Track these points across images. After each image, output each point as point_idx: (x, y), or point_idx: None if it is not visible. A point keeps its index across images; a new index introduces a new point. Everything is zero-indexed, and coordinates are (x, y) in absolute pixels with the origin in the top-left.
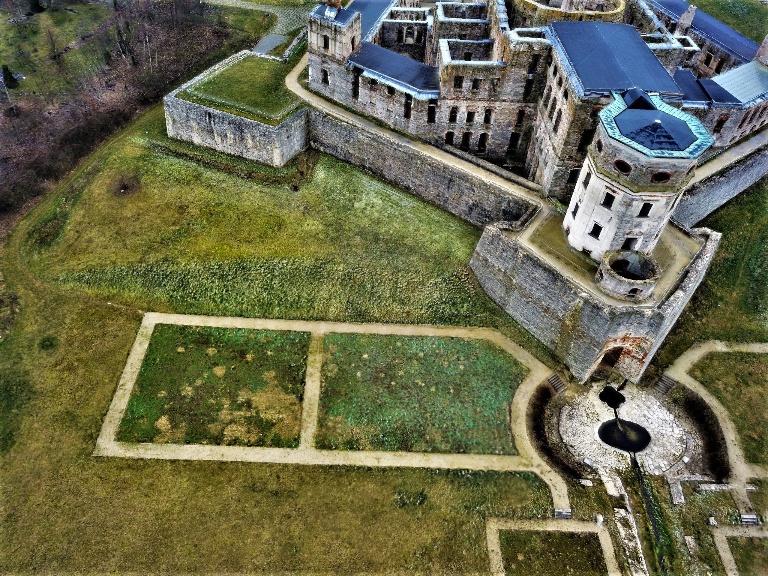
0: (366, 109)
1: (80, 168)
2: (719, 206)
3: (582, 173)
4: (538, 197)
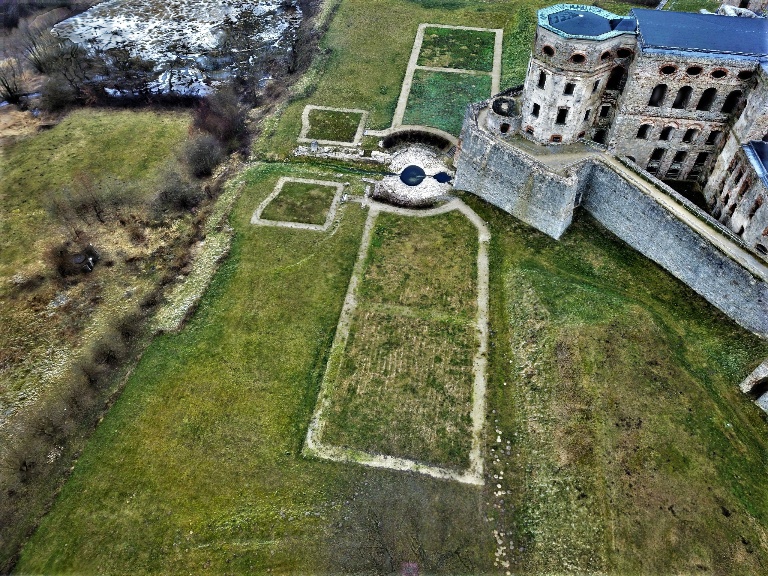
0: None
1: None
2: (670, 271)
3: None
4: None
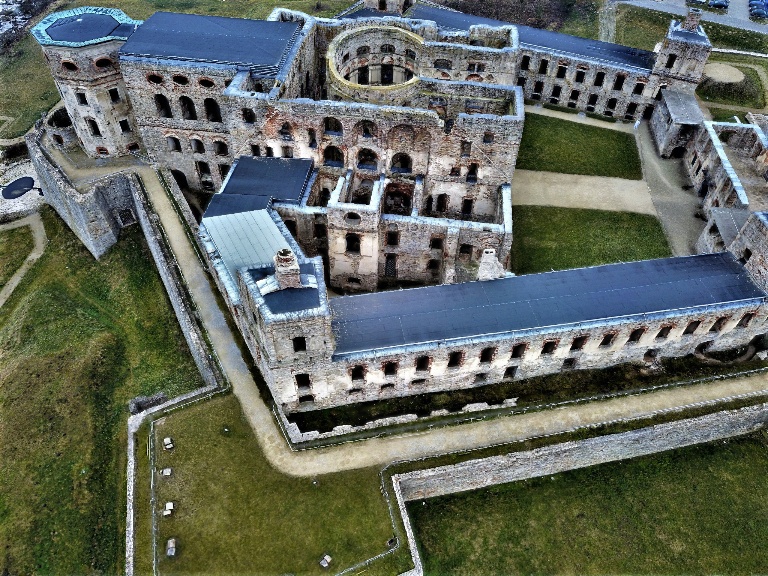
0: None
1: None
2: None
3: None
4: None
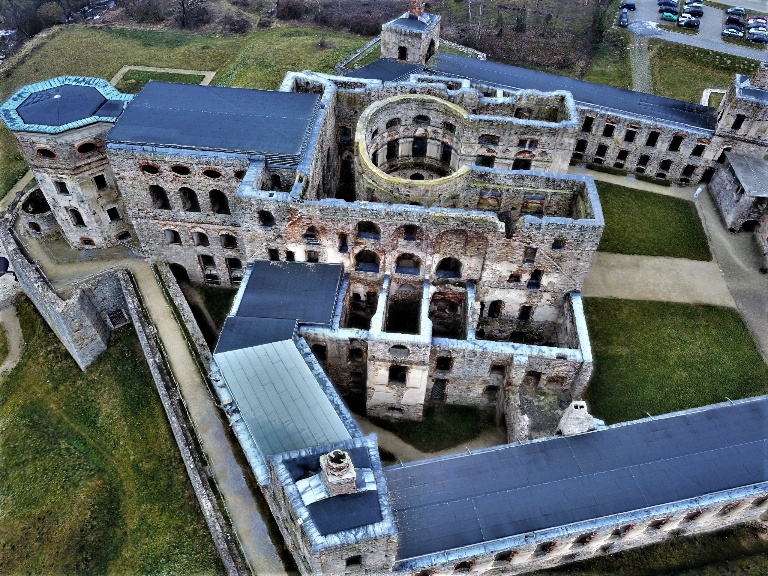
0: None
1: (362, 37)
2: None
3: None
4: None
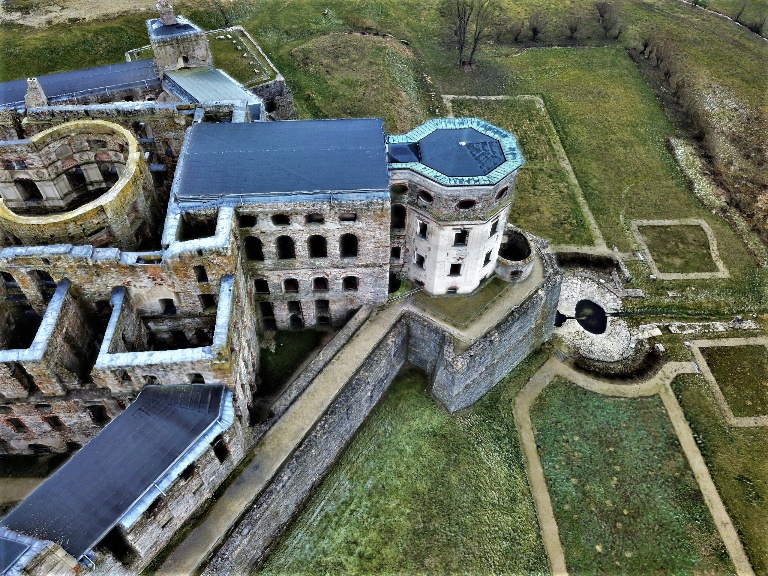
0: (161, 542)
1: None
2: None
3: (445, 242)
4: (381, 313)
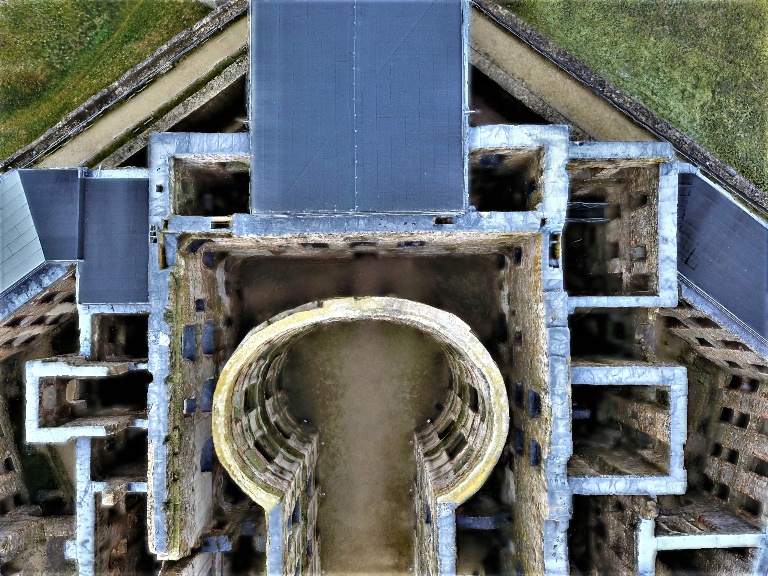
0: None
1: None
2: None
3: None
4: None
